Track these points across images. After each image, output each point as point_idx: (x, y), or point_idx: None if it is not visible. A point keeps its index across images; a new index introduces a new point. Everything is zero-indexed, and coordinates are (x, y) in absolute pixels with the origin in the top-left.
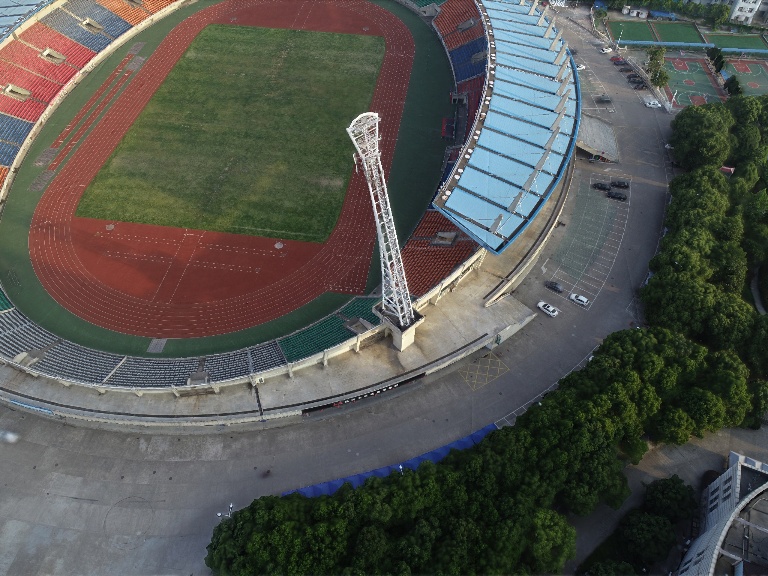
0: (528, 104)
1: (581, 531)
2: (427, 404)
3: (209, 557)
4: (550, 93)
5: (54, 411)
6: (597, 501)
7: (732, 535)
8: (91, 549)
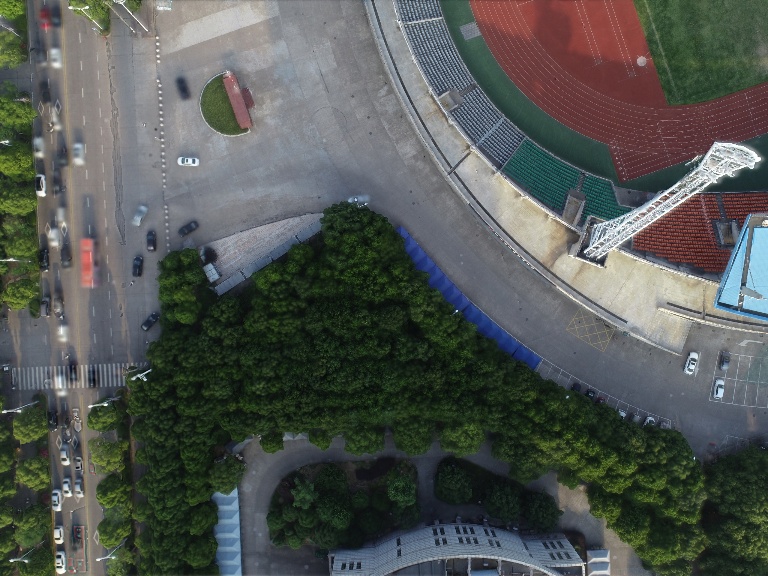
0: None
1: (486, 452)
2: (534, 297)
3: (328, 211)
4: None
5: (366, 4)
6: (507, 462)
7: (520, 565)
8: (298, 116)
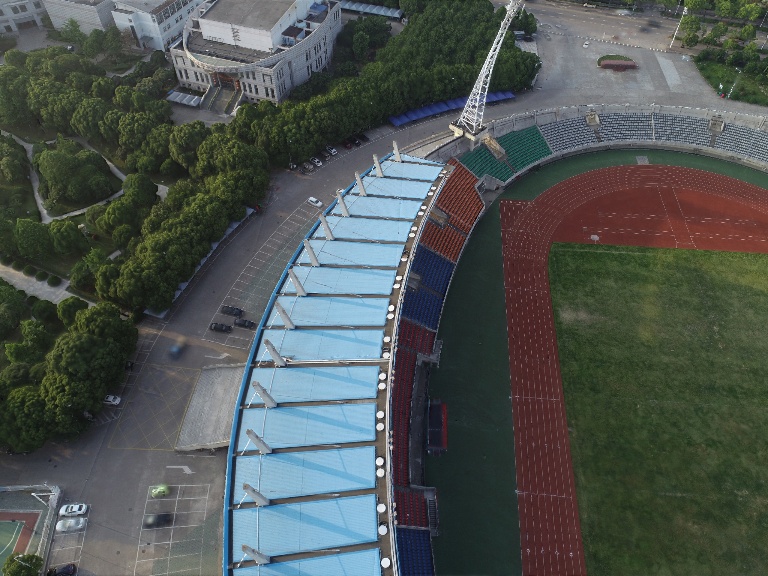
0: (341, 295)
1: None
2: None
3: None
4: (302, 328)
5: None
6: None
7: None
8: None
